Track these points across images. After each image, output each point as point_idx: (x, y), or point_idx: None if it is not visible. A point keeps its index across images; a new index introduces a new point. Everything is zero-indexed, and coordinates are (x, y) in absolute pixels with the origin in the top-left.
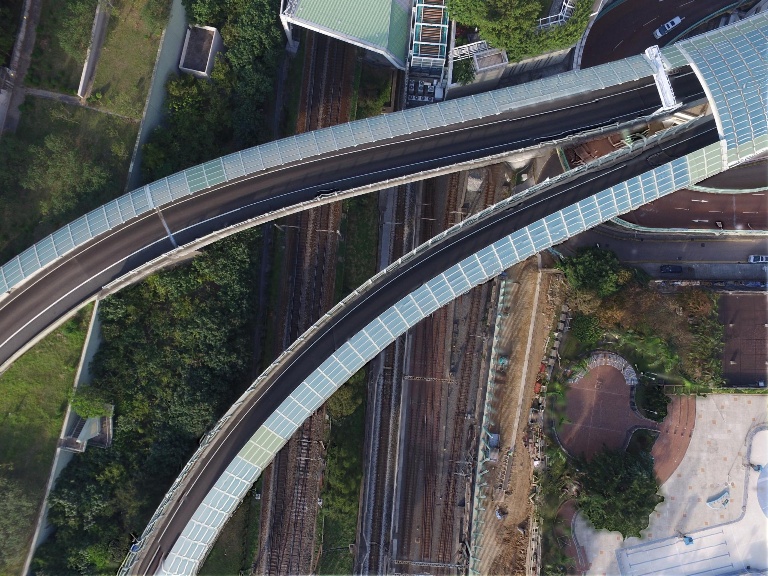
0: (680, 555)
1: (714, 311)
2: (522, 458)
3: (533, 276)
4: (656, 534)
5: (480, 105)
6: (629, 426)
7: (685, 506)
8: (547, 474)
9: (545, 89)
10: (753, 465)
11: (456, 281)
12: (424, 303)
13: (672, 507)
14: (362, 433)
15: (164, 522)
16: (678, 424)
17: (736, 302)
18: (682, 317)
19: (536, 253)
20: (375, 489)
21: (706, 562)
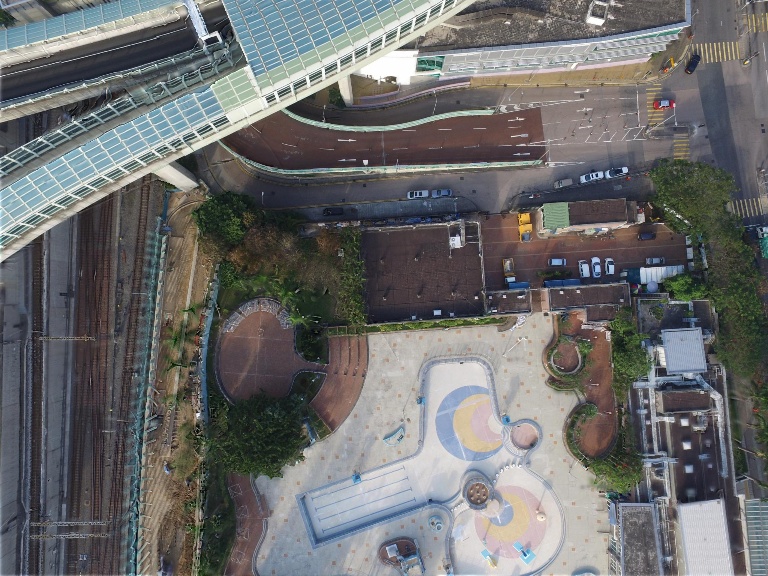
0: (364, 494)
1: (355, 248)
2: (185, 411)
3: (193, 229)
4: (335, 476)
5: (17, 47)
6: (294, 371)
7: (363, 445)
8: (214, 425)
9: (100, 28)
10: None
11: None
12: None
13: (350, 448)
14: None
15: None
16: (347, 365)
17: (387, 238)
18: None
19: (102, 196)
20: (31, 455)
21: (389, 499)
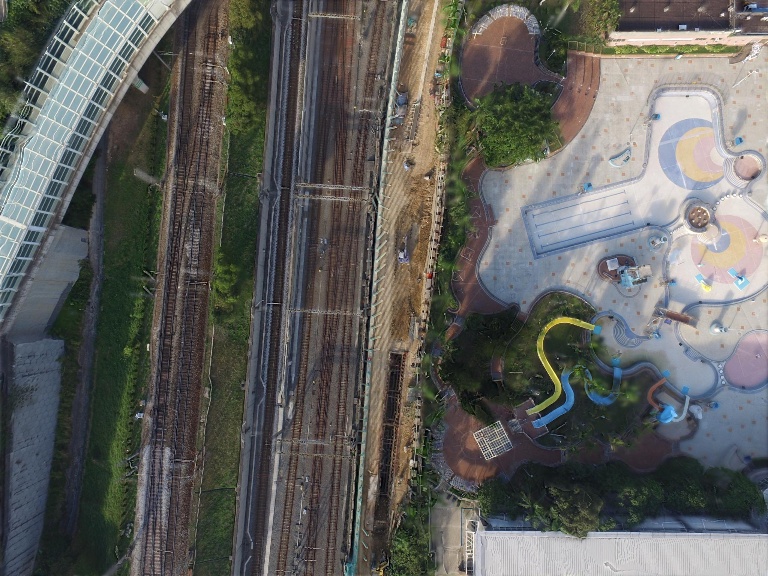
0: (584, 215)
1: None
2: (428, 110)
3: None
4: (560, 192)
5: None
6: (533, 81)
7: (588, 165)
8: (453, 127)
9: None
10: (652, 115)
11: None
12: None
13: (576, 166)
14: (267, 66)
15: None
16: (582, 83)
17: None
18: None
19: None
20: (285, 136)
21: (608, 221)
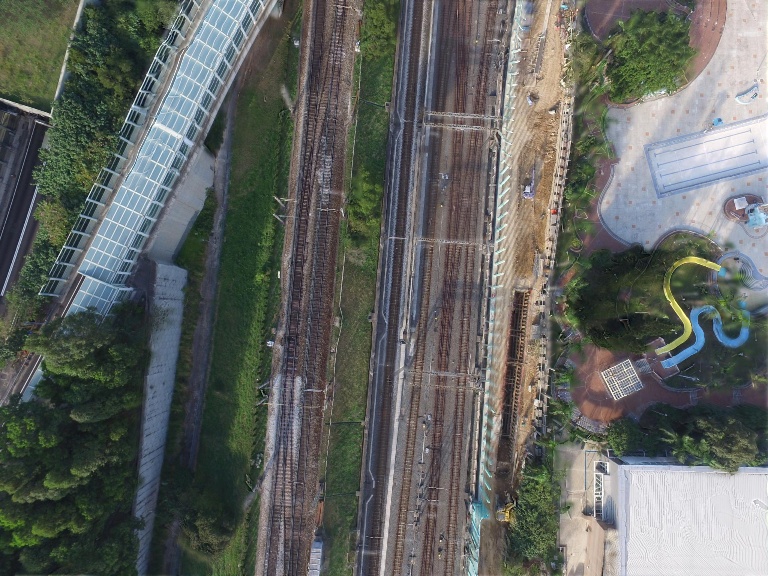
0: (708, 154)
1: None
2: (554, 43)
3: None
4: (684, 129)
5: None
6: None
7: (714, 102)
8: (578, 61)
9: None
10: None
11: None
12: None
13: (701, 103)
14: None
15: (210, 5)
16: (709, 17)
17: None
18: None
19: None
20: (409, 68)
21: (733, 160)
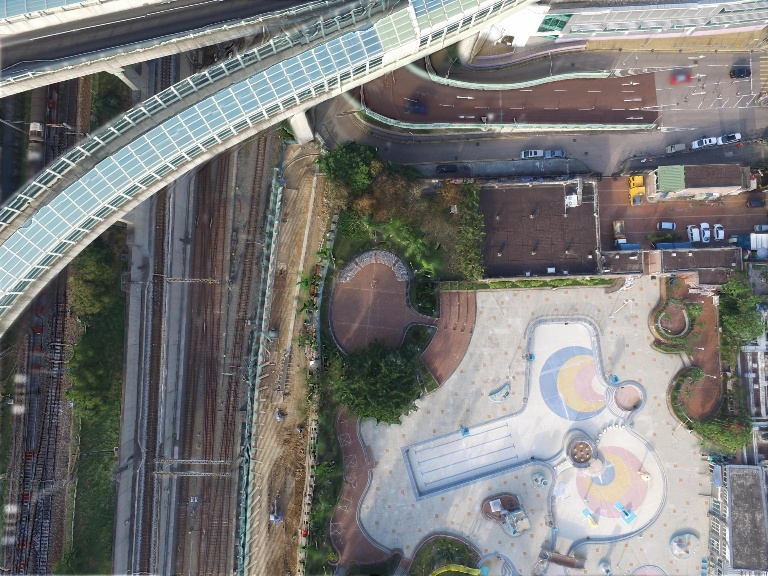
0: (467, 450)
1: (474, 202)
2: (299, 359)
3: (309, 181)
4: (440, 430)
5: None
6: (406, 323)
7: (468, 401)
8: (325, 374)
9: None
10: (527, 355)
11: (146, 154)
12: (114, 177)
13: (455, 403)
14: (122, 336)
15: None
16: (457, 320)
17: (503, 195)
18: (457, 215)
19: (252, 134)
20: (149, 396)
21: (492, 455)
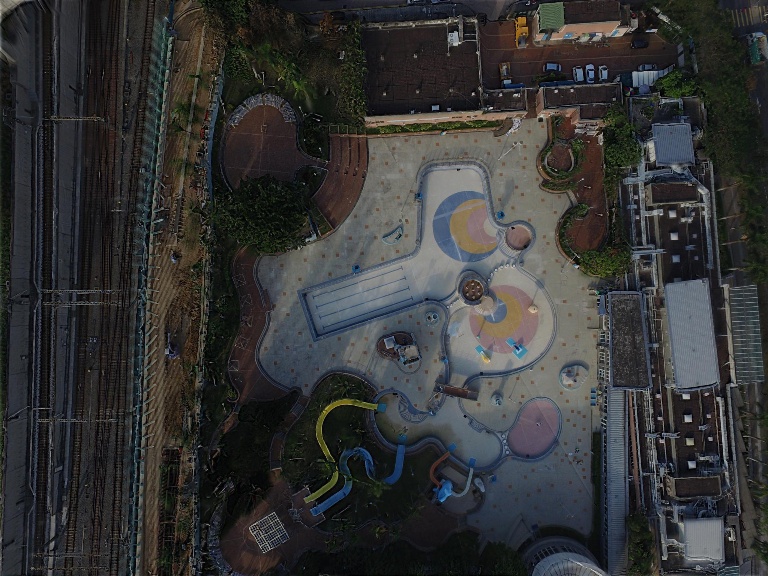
0: (363, 293)
1: (356, 39)
2: (191, 202)
3: (198, 30)
4: (336, 273)
5: None
6: (297, 167)
7: (362, 244)
8: None
9: None
10: (415, 194)
11: None
12: None
13: (350, 246)
14: (9, 173)
15: None
16: (348, 164)
17: (387, 36)
18: None
19: None
20: (43, 238)
21: (388, 297)
